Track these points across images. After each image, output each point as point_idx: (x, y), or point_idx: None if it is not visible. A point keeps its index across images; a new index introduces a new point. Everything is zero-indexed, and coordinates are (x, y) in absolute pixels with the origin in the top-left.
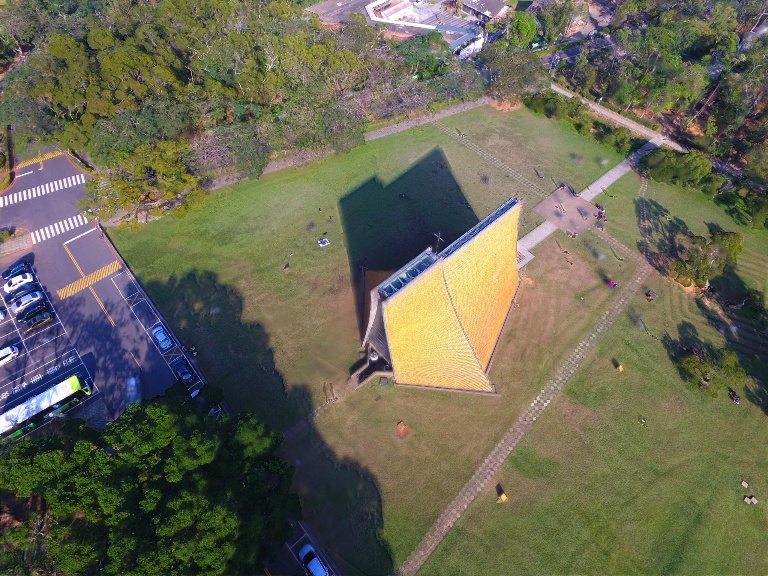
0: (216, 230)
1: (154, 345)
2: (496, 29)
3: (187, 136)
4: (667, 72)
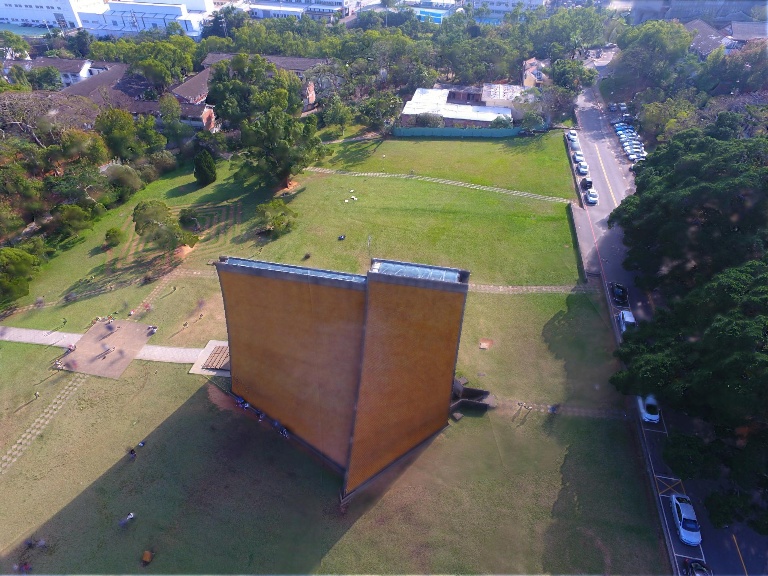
0: None
1: None
2: None
3: None
4: None
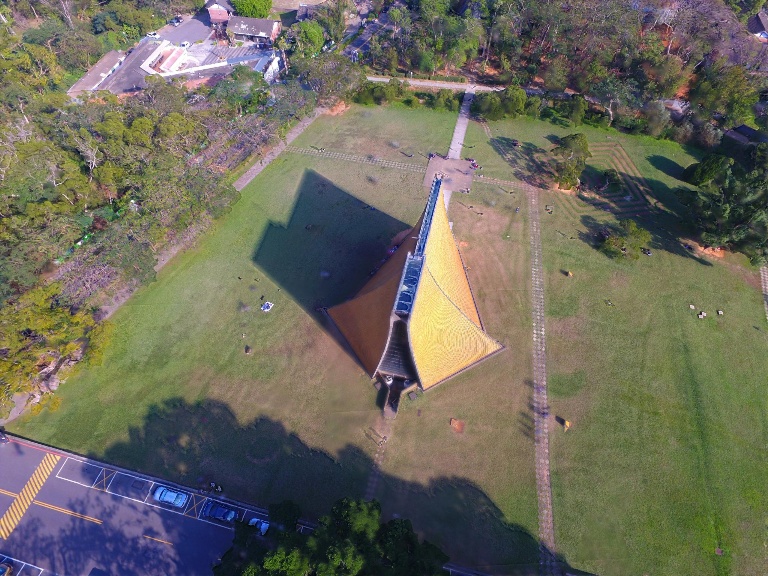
0: (144, 356)
1: (166, 510)
2: (290, 45)
3: (49, 275)
4: (454, 32)
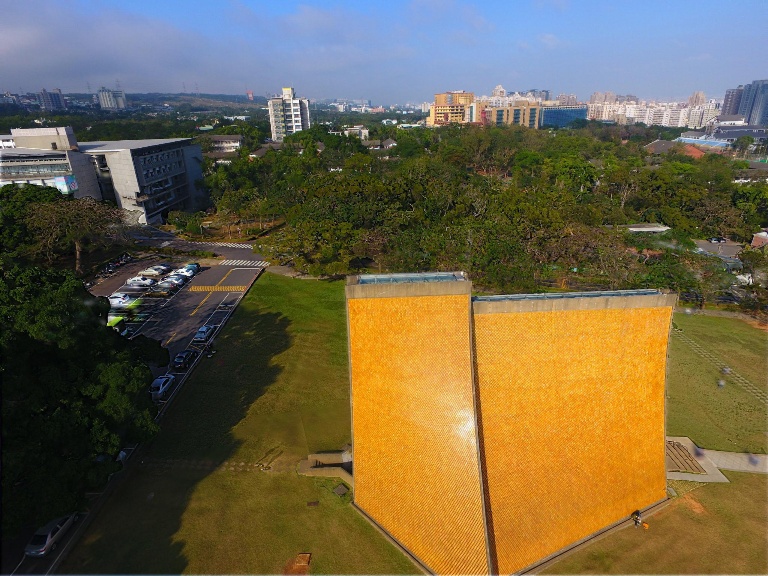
0: (334, 299)
1: (194, 336)
2: None
3: (366, 228)
4: None
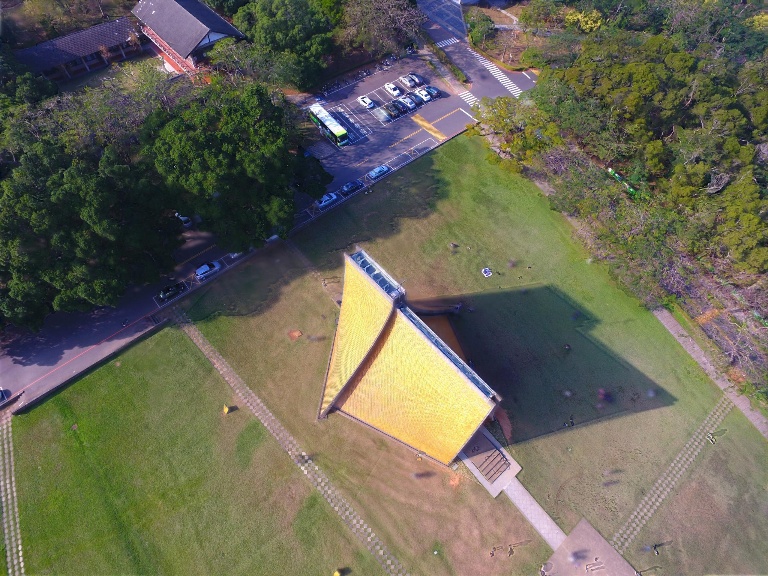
0: (488, 191)
1: None
2: None
3: None
4: None
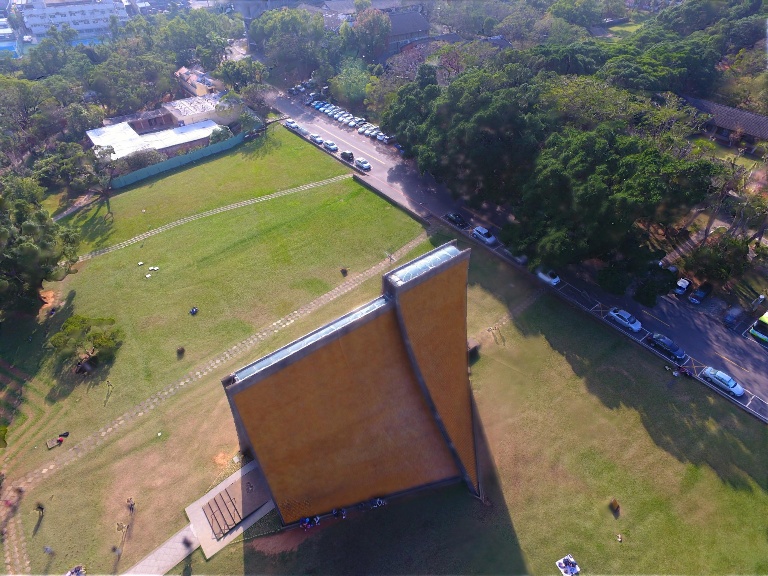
0: None
1: None
2: None
3: None
4: None
